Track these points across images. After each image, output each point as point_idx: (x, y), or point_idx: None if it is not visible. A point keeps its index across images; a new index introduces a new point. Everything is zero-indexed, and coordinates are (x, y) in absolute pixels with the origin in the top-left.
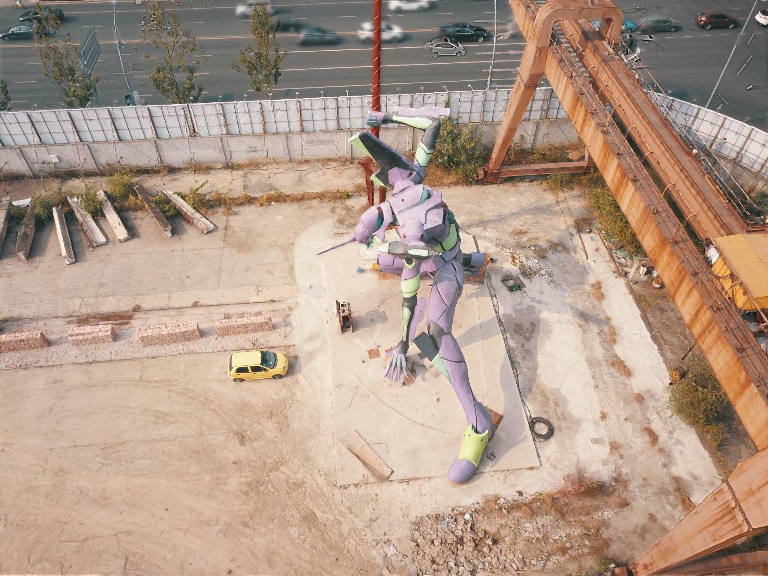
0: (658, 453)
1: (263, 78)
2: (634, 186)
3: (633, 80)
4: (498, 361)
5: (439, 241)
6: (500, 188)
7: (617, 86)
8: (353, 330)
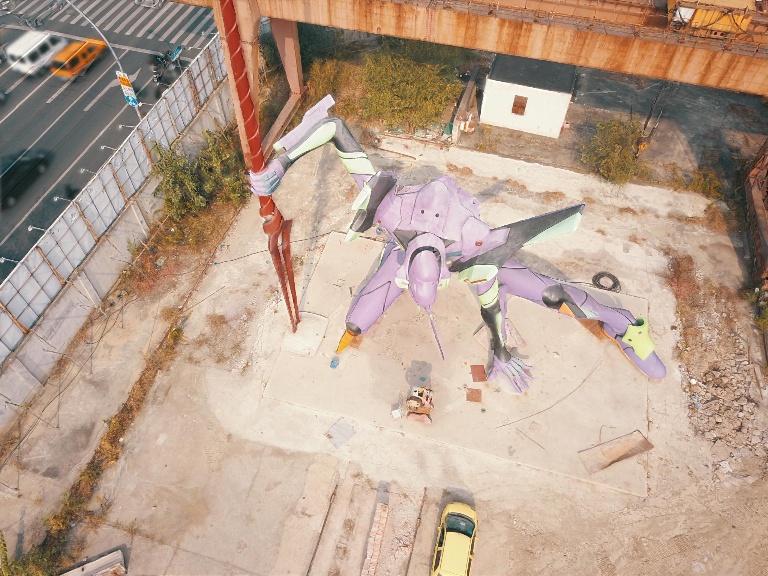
0: (645, 215)
1: None
2: (545, 24)
3: None
4: None
5: None
6: None
7: None
8: None
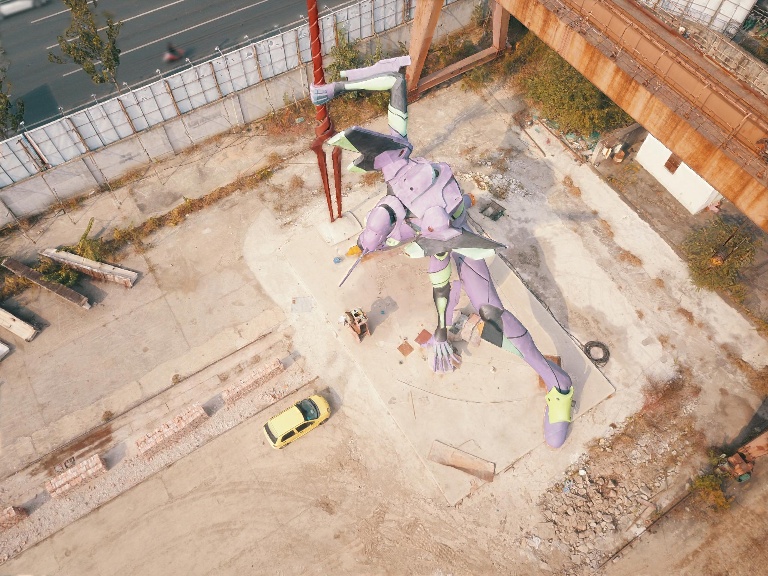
0: (699, 329)
1: (104, 64)
2: (649, 91)
3: None
4: (525, 302)
5: None
6: (422, 105)
7: None
8: (370, 332)
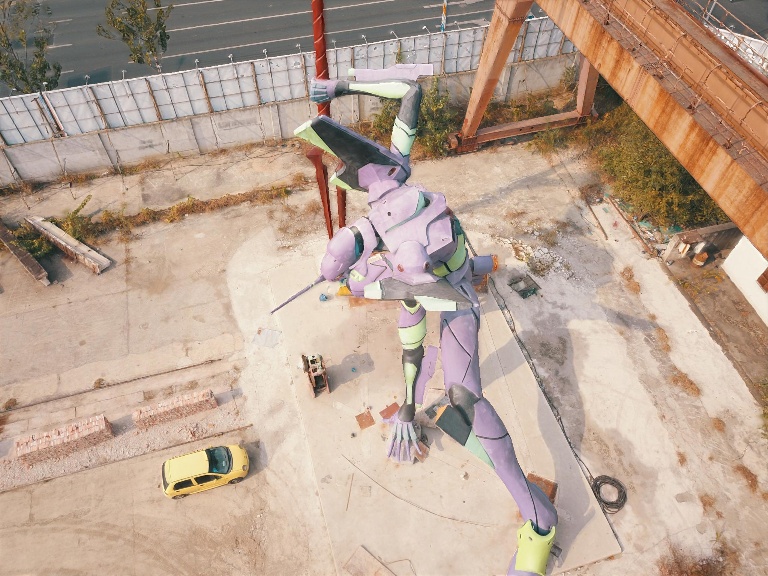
0: (763, 501)
1: (145, 44)
2: (730, 155)
3: None
4: (532, 402)
5: (443, 261)
6: (478, 157)
7: (646, 8)
8: (330, 389)
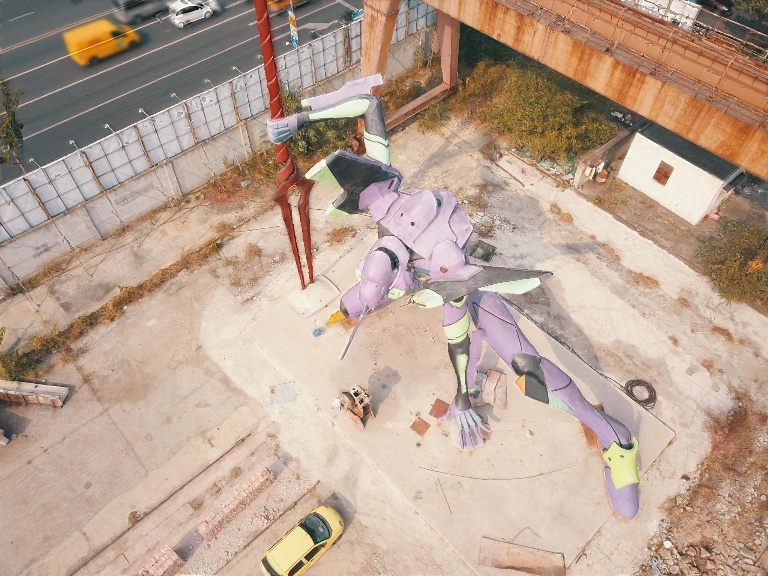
0: (742, 347)
1: (3, 141)
2: (660, 80)
3: None
4: (545, 347)
5: None
6: None
7: None
8: (373, 413)
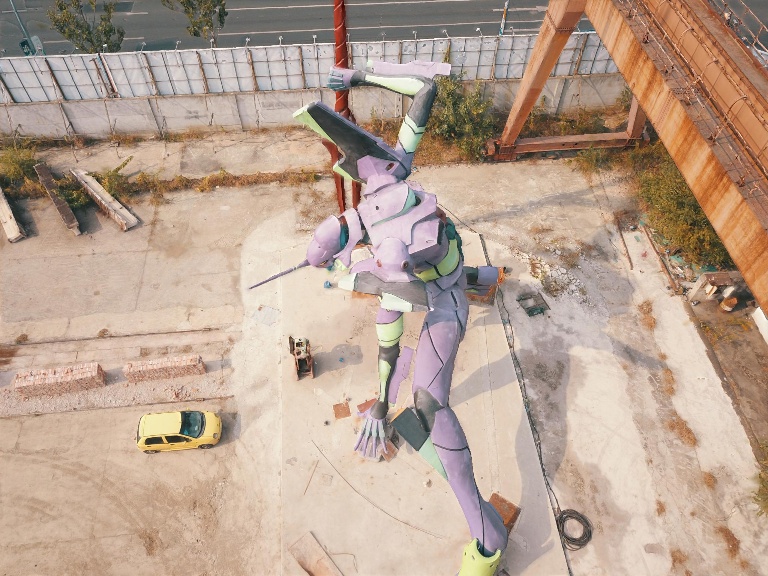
0: (741, 569)
1: (202, 18)
2: (741, 194)
3: (721, 21)
4: (513, 422)
5: (432, 264)
6: (515, 167)
7: (696, 30)
8: (314, 374)
